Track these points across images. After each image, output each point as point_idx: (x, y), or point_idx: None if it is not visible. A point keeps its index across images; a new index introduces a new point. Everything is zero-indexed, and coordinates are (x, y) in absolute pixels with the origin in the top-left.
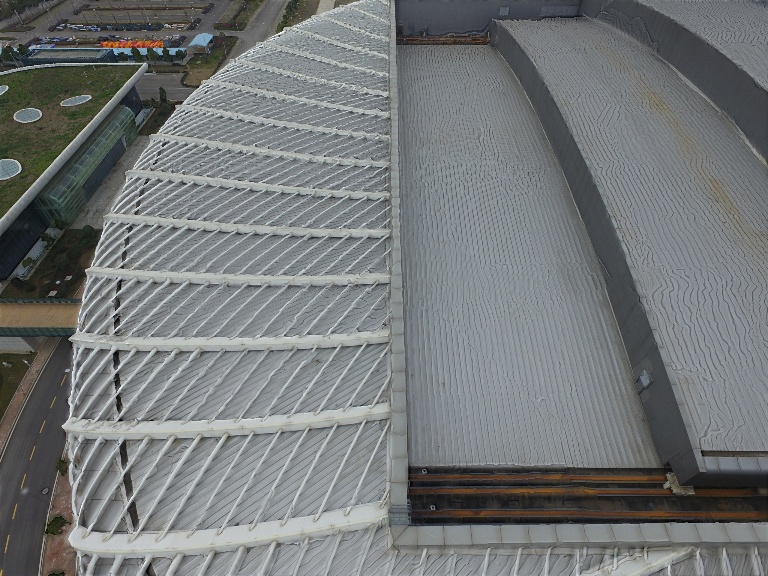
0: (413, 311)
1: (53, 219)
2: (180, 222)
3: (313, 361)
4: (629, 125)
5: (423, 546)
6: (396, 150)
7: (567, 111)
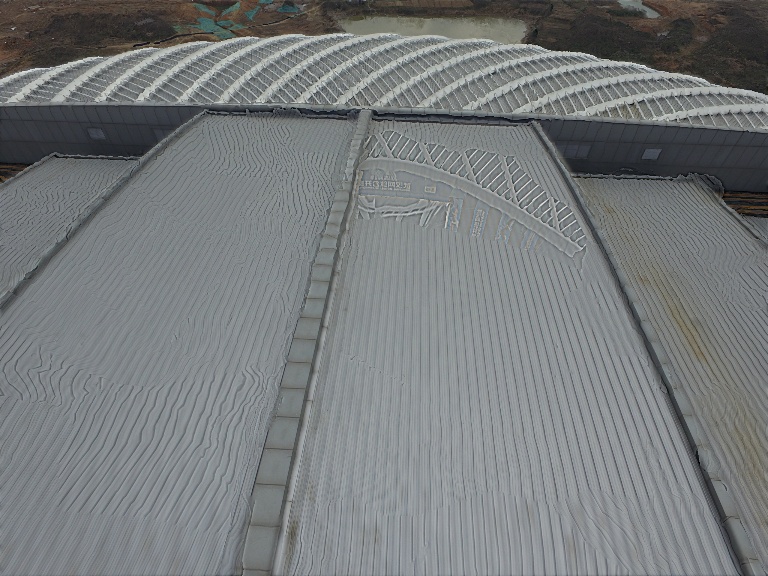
0: None
1: None
2: None
3: None
4: None
5: None
6: None
7: None
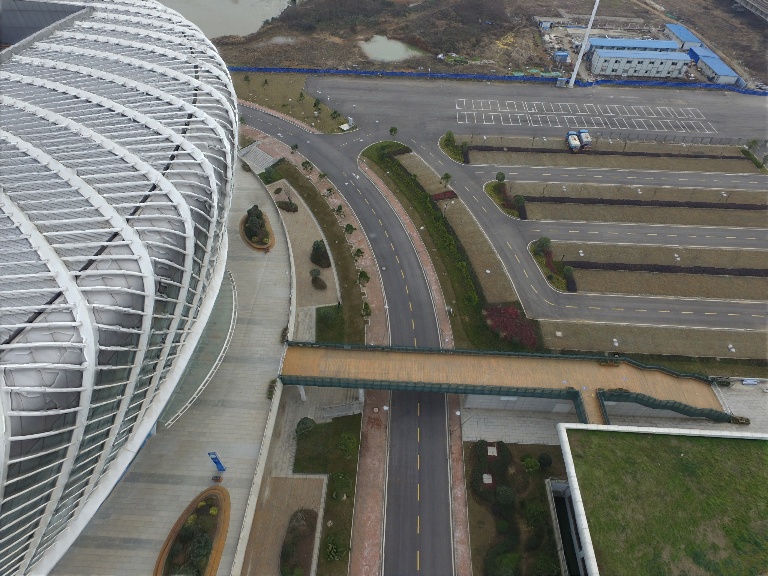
0: None
1: None
2: (147, 85)
3: None
4: None
5: None
6: None
7: None
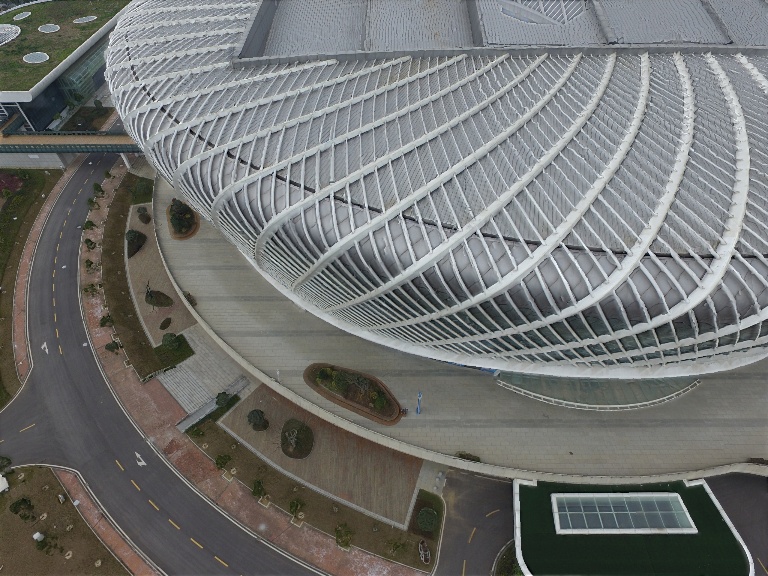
0: (272, 44)
1: (72, 98)
2: (158, 9)
3: (214, 38)
4: None
5: (243, 65)
6: None
7: None
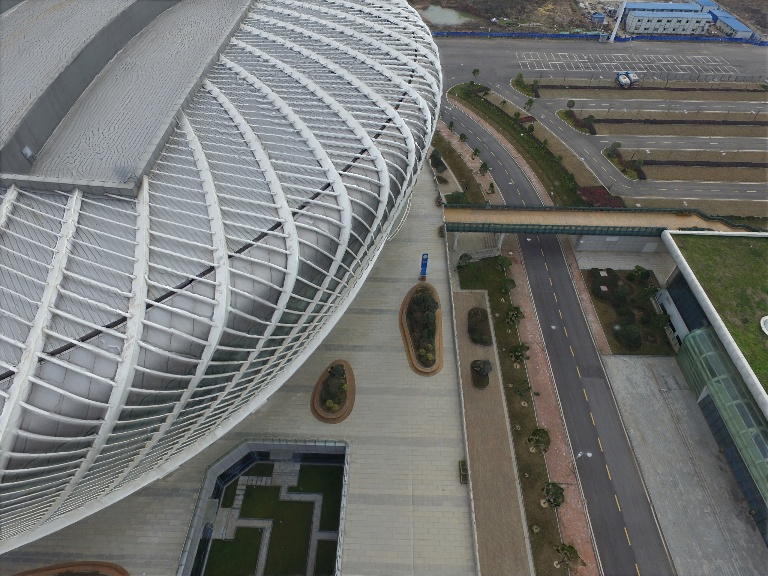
0: None
1: None
2: None
3: None
4: (97, 4)
5: None
6: None
7: (129, 3)
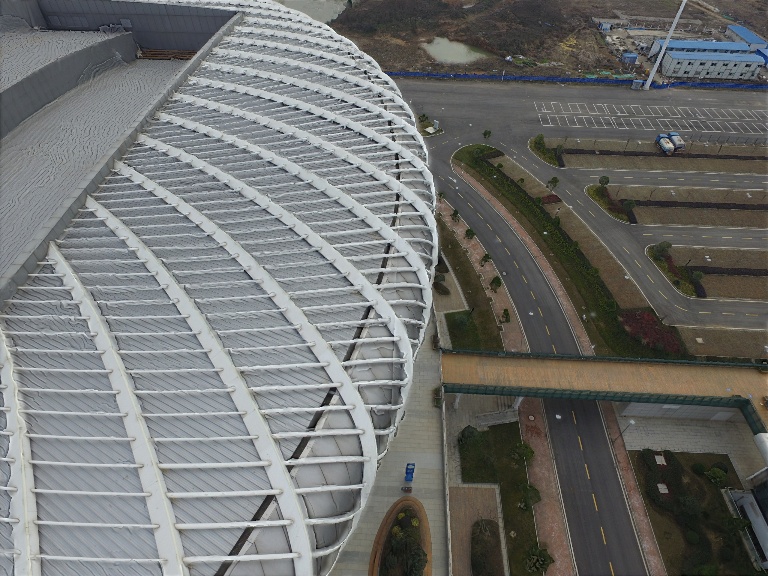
0: None
1: None
2: None
3: None
4: None
5: None
6: (162, 91)
7: None
